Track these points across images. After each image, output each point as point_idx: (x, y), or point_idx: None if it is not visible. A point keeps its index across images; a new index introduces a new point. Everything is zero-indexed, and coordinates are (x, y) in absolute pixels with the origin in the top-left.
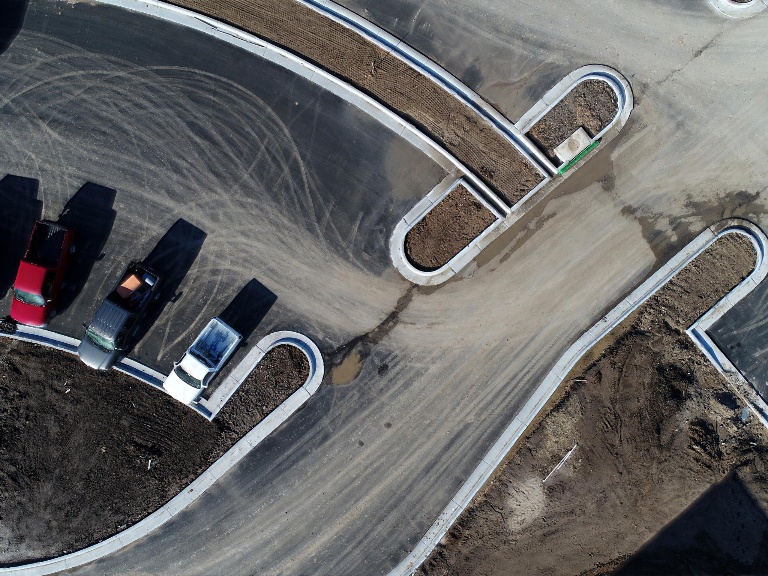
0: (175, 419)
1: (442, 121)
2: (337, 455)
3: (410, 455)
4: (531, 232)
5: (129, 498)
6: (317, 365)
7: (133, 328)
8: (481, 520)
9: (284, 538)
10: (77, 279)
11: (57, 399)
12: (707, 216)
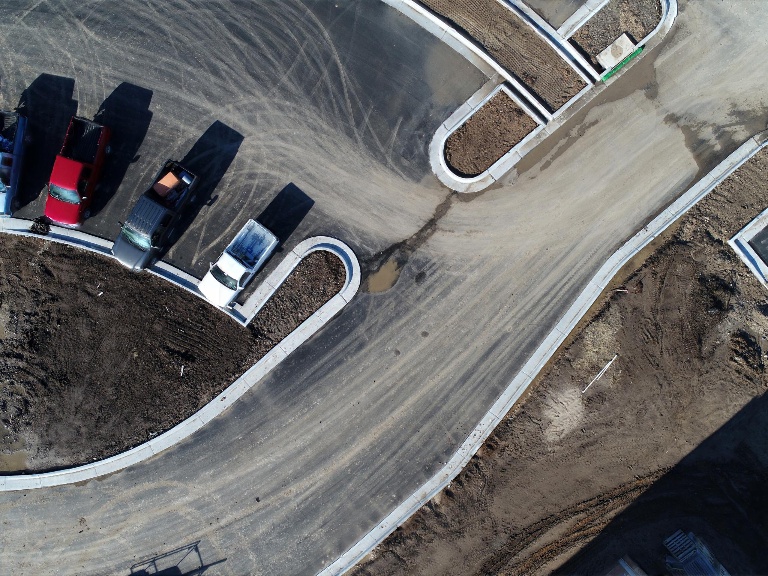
0: (209, 324)
1: (483, 26)
2: (373, 364)
3: (447, 365)
4: (572, 140)
5: (161, 405)
6: (354, 272)
7: (169, 227)
8: (519, 431)
9: (318, 448)
10: (111, 180)
11: (89, 302)
12: (751, 126)
